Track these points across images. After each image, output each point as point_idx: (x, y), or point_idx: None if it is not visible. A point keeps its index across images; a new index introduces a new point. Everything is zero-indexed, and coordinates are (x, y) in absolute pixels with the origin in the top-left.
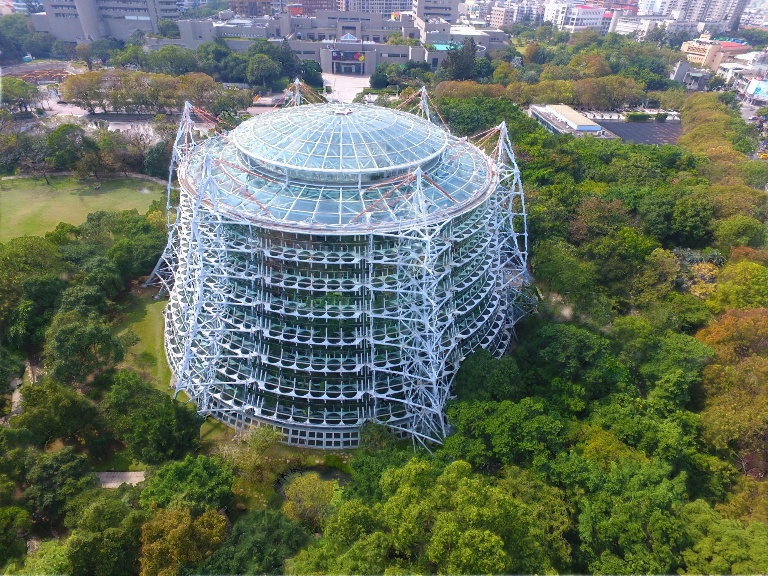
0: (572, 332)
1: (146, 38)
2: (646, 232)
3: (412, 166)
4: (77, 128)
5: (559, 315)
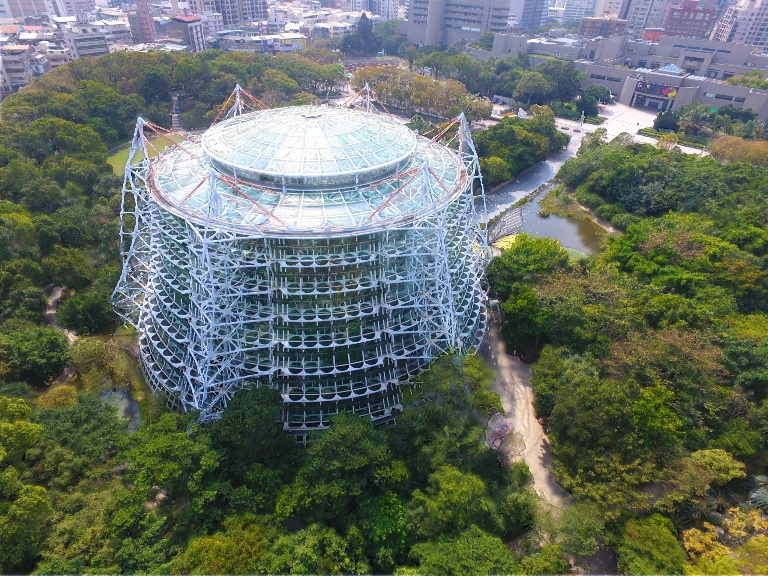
0: (339, 429)
1: (466, 47)
2: (754, 423)
3: (286, 177)
4: None
5: (408, 419)
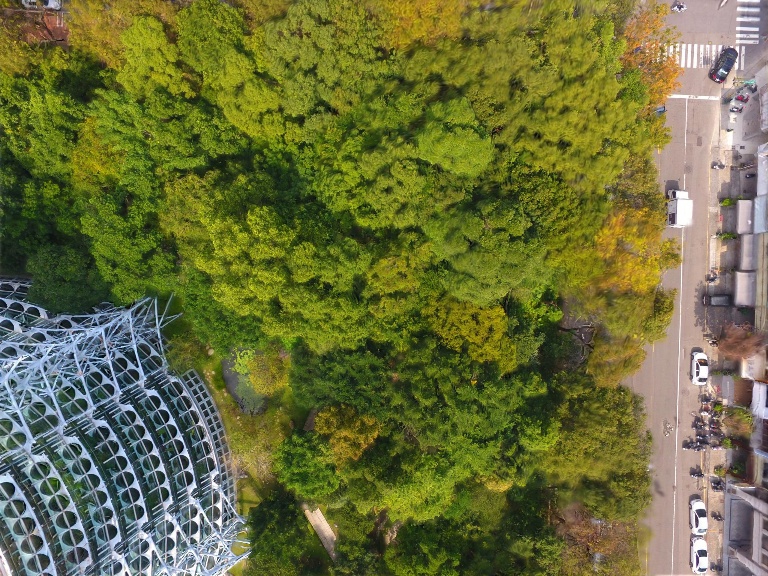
0: None
1: None
2: None
3: None
4: None
5: None
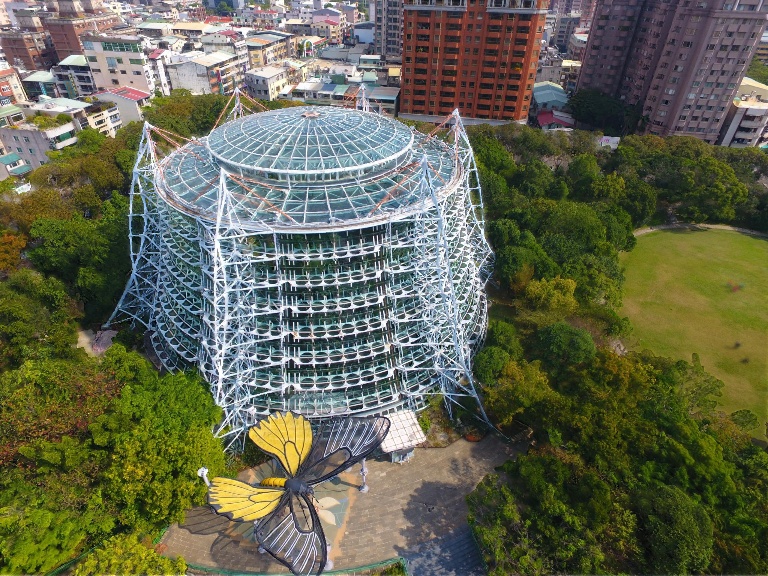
0: None
1: None
2: None
3: None
4: None
5: None
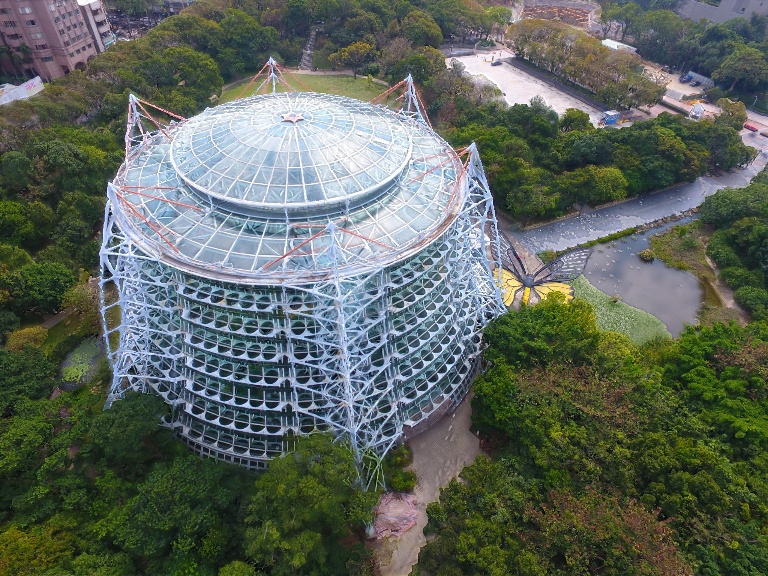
0: None
1: None
2: None
3: None
4: (421, 62)
5: (259, 487)
